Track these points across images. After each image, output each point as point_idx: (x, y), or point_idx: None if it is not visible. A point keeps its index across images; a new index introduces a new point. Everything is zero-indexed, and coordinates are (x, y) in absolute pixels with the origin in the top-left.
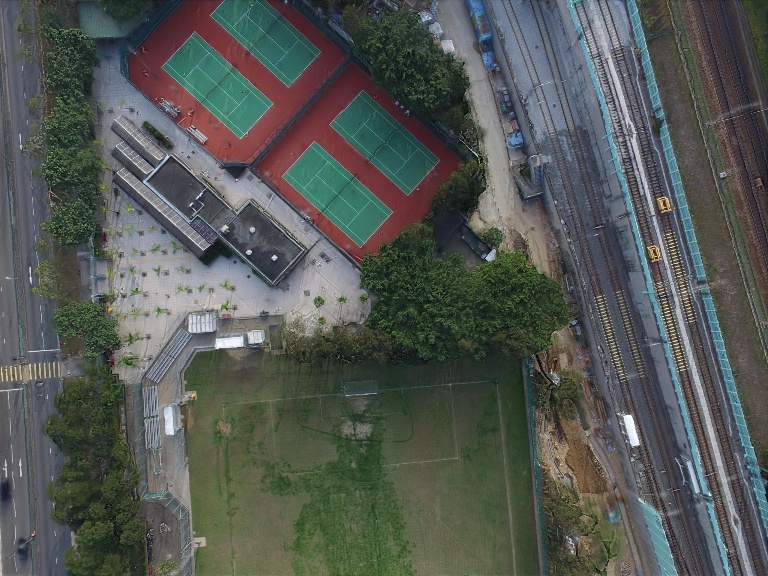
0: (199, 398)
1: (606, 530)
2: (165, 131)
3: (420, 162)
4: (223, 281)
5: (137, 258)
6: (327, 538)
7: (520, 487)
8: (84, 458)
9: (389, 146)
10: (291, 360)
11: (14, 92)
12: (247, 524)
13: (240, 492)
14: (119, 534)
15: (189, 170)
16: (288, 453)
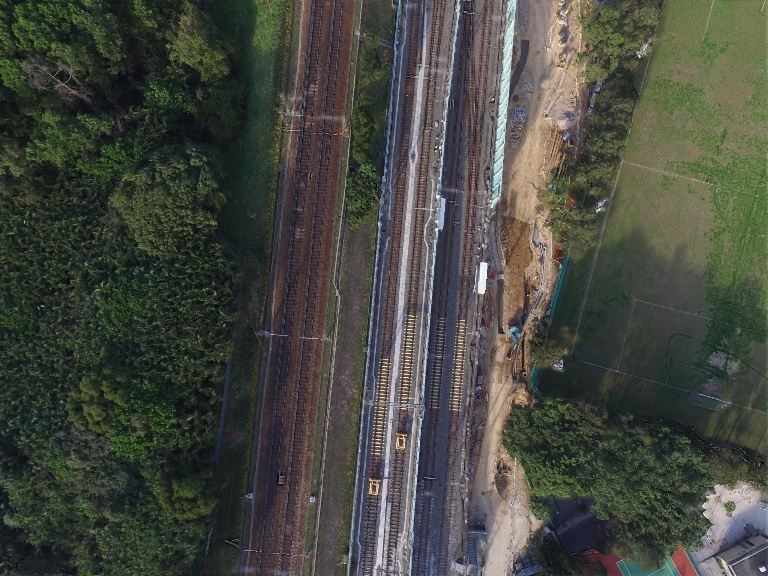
0: None
1: (519, 182)
2: None
3: None
4: None
5: None
6: None
7: None
8: None
9: None
10: (766, 453)
11: None
12: None
13: None
14: None
15: None
16: None
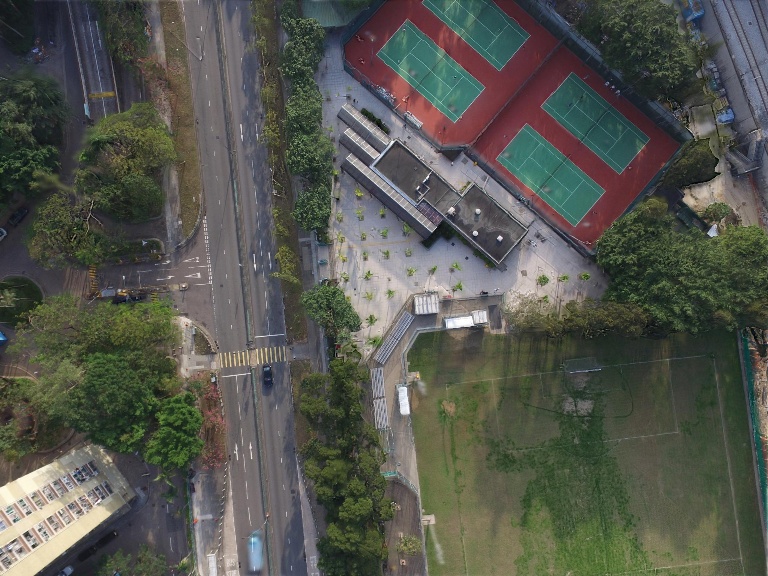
0: (423, 378)
1: None
2: (381, 117)
3: (631, 141)
4: (442, 263)
5: (357, 243)
6: (553, 513)
7: (741, 459)
8: (341, 437)
9: (600, 126)
10: (511, 339)
11: (234, 83)
12: (474, 501)
13: (466, 470)
14: (378, 510)
15: (414, 154)
16: (512, 431)
